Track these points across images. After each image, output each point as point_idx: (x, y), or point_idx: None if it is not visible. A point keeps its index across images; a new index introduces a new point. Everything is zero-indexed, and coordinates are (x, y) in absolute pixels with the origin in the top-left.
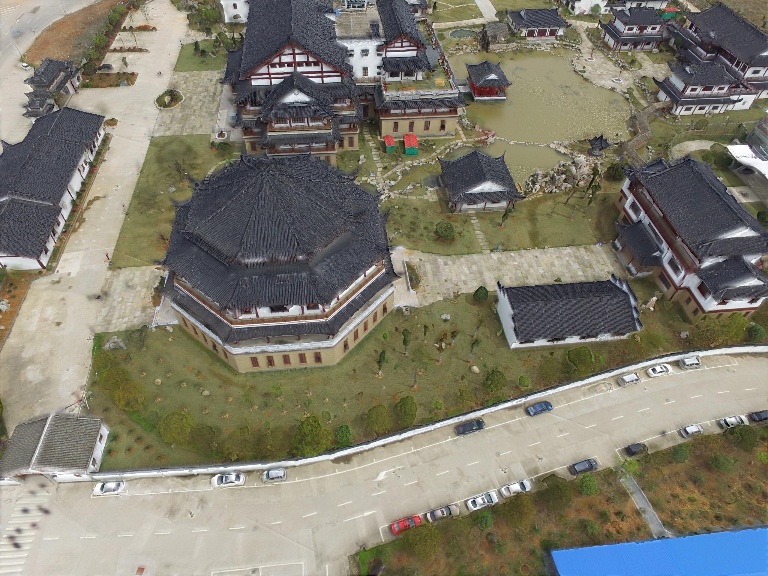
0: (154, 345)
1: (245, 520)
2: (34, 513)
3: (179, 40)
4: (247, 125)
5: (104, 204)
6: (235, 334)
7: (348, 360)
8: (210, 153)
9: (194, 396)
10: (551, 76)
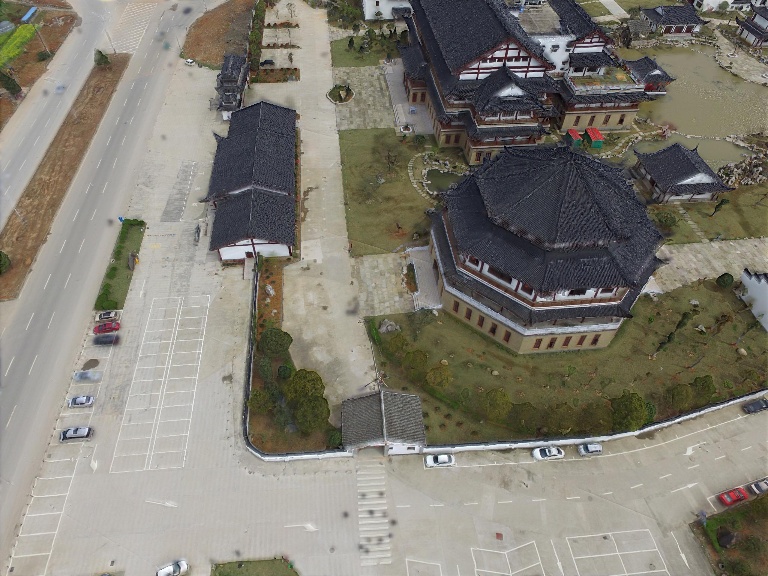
0: (426, 328)
1: (578, 490)
2: (377, 483)
3: (325, 37)
4: (450, 119)
5: (320, 195)
6: (535, 316)
7: (616, 343)
8: (402, 146)
9: (484, 376)
10: (699, 72)
